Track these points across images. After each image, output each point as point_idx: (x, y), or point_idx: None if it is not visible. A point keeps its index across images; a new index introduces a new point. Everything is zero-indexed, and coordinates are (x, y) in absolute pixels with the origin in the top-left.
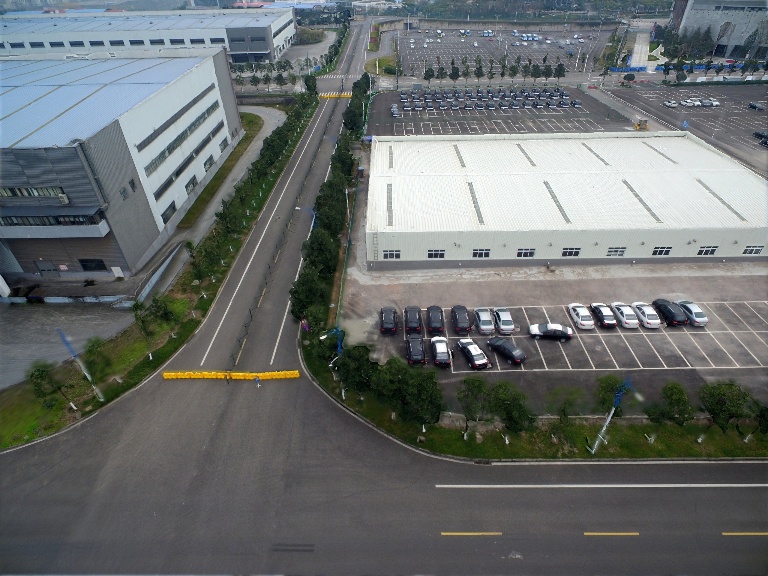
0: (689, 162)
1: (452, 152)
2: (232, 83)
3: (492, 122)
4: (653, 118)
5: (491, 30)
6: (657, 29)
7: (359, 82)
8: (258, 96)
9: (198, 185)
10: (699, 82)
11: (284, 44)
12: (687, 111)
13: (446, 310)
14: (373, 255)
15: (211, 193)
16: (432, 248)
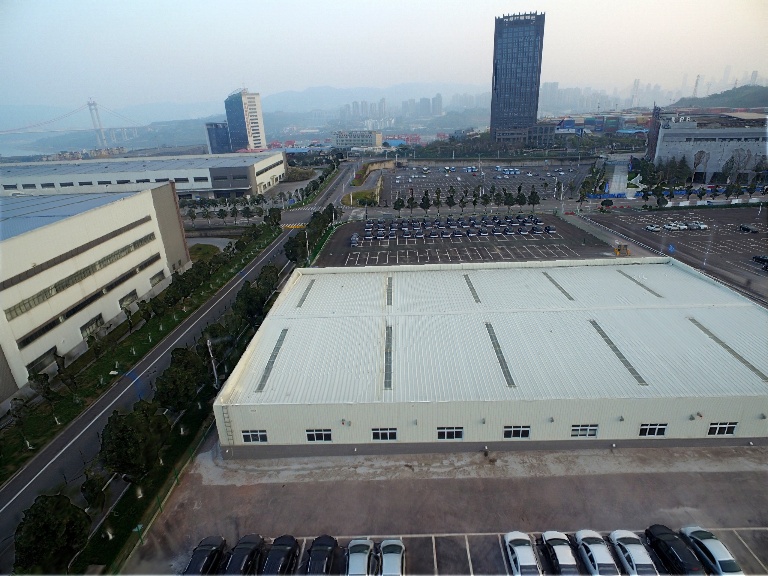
0: (677, 295)
1: (383, 286)
2: (179, 216)
3: (456, 250)
4: (635, 243)
5: (475, 166)
6: (633, 161)
7: (318, 212)
8: (223, 228)
9: (105, 325)
10: (682, 206)
11: (270, 181)
12: (673, 235)
13: (309, 541)
14: (227, 437)
15: (119, 334)
16: (312, 427)
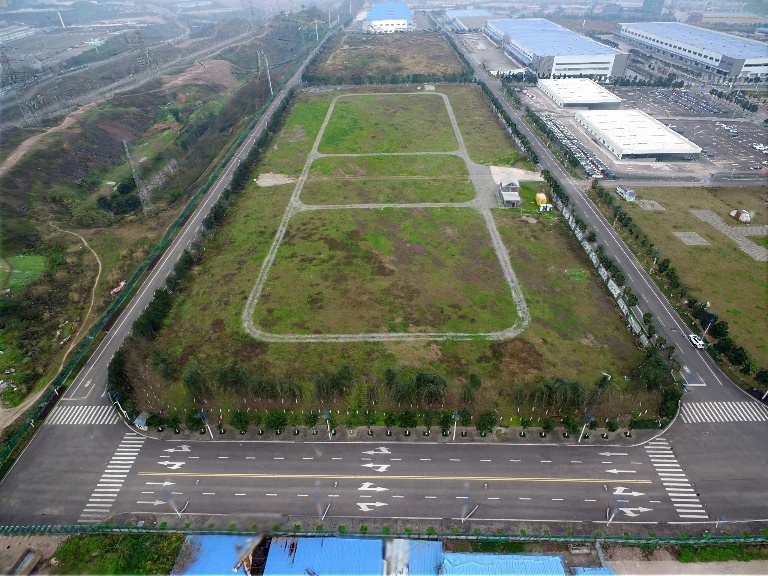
0: None
1: None
2: (626, 66)
3: None
4: None
5: None
6: None
7: (661, 79)
8: None
9: None
10: None
11: None
12: None
13: None
14: None
15: None
16: None
